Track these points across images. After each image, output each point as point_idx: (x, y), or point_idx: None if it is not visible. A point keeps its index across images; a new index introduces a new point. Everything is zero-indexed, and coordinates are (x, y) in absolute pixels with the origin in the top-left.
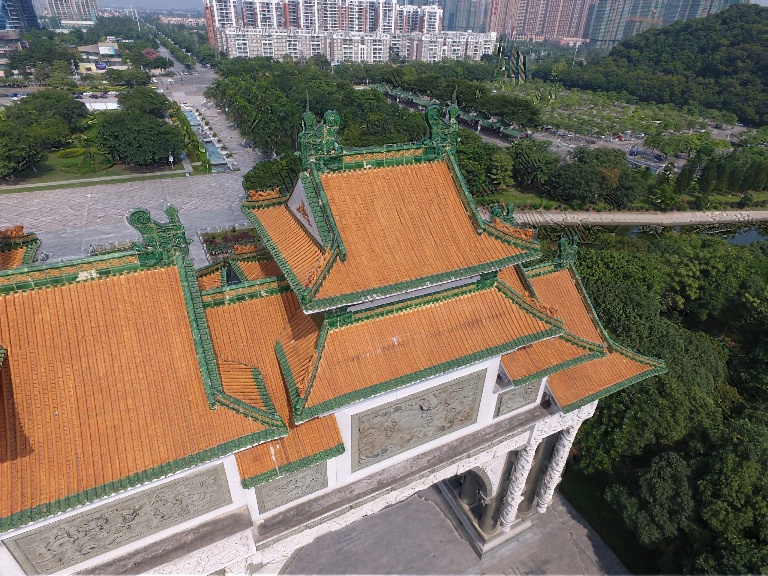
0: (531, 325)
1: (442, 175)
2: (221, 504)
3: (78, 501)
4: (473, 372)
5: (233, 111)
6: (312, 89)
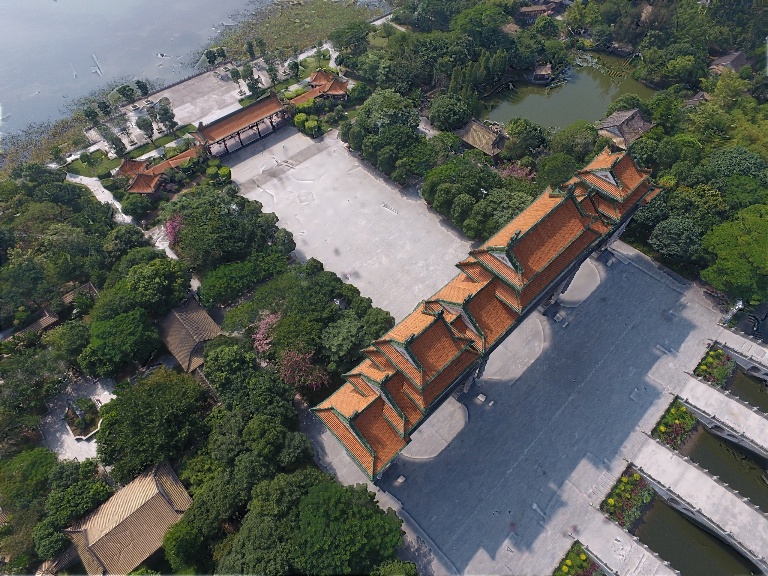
0: None
1: None
2: None
3: None
4: None
5: None
6: None
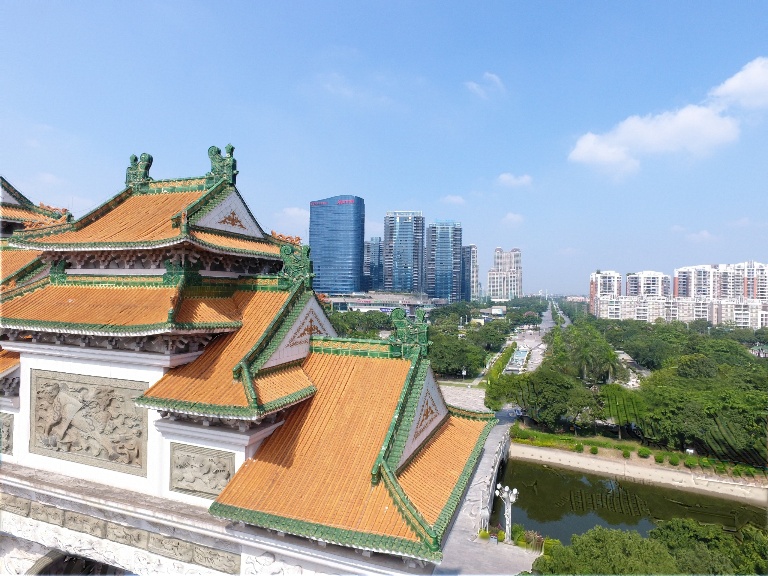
0: None
1: None
2: None
3: None
4: (134, 380)
5: (551, 348)
6: (650, 338)
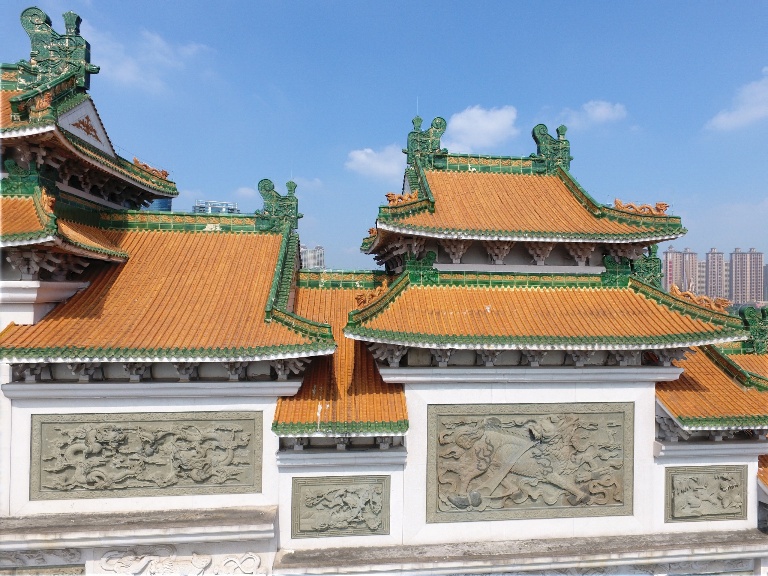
0: (690, 326)
1: (553, 184)
2: (248, 487)
3: (107, 353)
4: (611, 401)
5: None
6: None
